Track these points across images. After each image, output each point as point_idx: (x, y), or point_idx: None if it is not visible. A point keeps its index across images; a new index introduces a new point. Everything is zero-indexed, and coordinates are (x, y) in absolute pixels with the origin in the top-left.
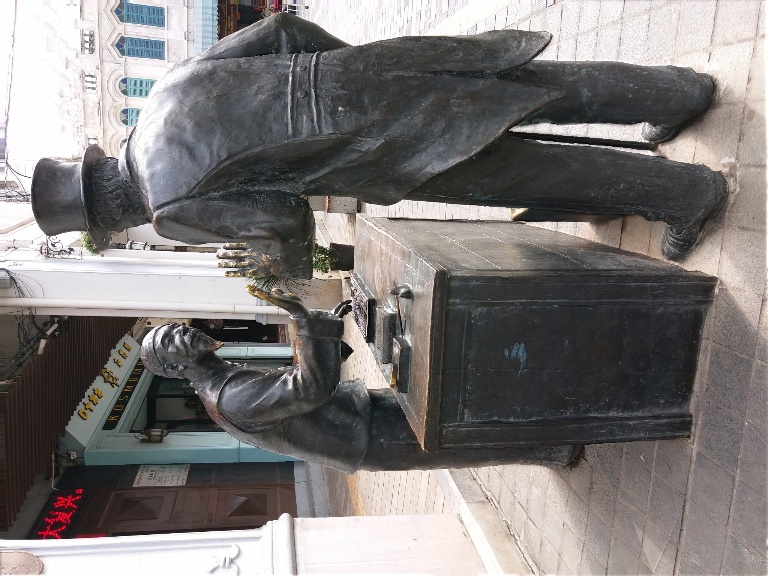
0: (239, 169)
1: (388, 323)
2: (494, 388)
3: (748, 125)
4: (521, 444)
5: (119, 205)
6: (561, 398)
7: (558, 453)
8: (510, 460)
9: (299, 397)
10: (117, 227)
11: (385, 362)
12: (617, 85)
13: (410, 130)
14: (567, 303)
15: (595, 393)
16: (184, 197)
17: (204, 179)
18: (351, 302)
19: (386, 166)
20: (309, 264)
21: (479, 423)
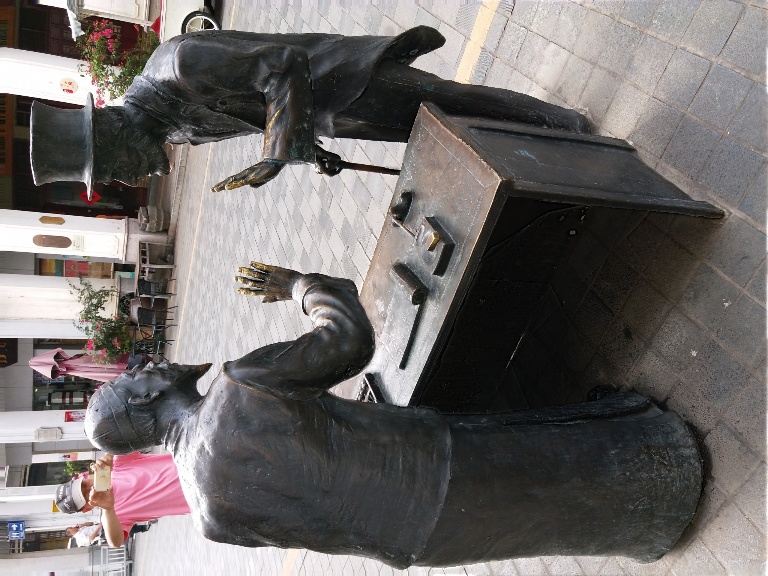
0: None
1: (400, 268)
2: None
3: (563, 93)
4: (588, 196)
5: (119, 120)
6: None
7: (674, 434)
8: (631, 447)
9: (334, 334)
10: (107, 160)
11: (416, 289)
12: None
13: None
14: None
15: (614, 184)
16: None
17: (219, 32)
18: None
19: (353, 49)
20: (312, 131)
21: None
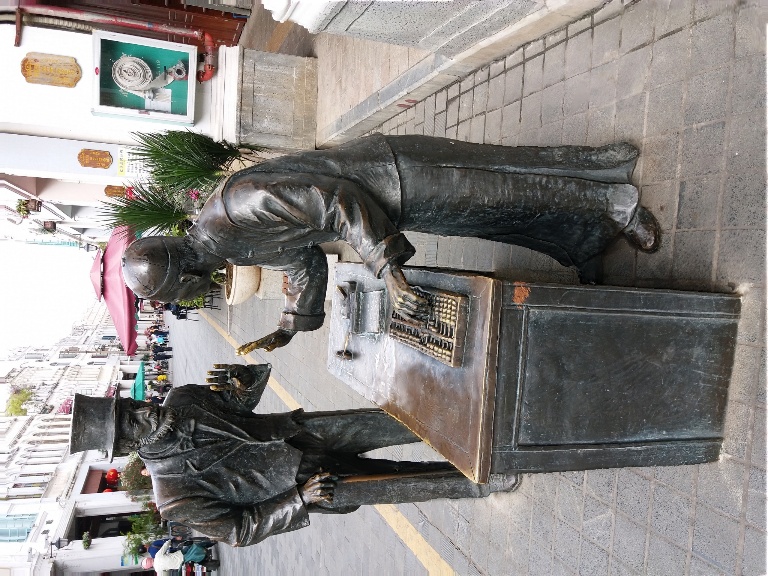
0: None
1: None
2: None
3: None
4: None
5: None
6: None
7: None
8: None
9: None
10: None
11: None
12: None
13: None
14: None
15: None
16: None
17: None
18: (446, 318)
19: None
20: None
21: None
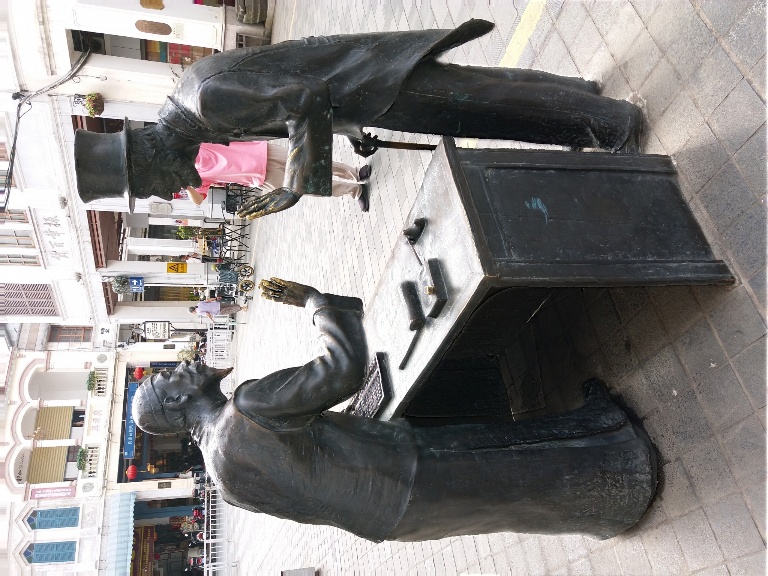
0: (269, 63)
1: (407, 288)
2: (529, 233)
3: (627, 70)
4: (578, 279)
5: (153, 145)
6: (595, 245)
7: (635, 460)
8: (586, 473)
9: (329, 370)
10: (144, 183)
11: (414, 319)
12: (529, 71)
13: (395, 38)
14: (561, 167)
15: (624, 242)
16: (226, 71)
17: (243, 61)
18: None
19: (383, 60)
20: (330, 165)
21: (529, 259)
